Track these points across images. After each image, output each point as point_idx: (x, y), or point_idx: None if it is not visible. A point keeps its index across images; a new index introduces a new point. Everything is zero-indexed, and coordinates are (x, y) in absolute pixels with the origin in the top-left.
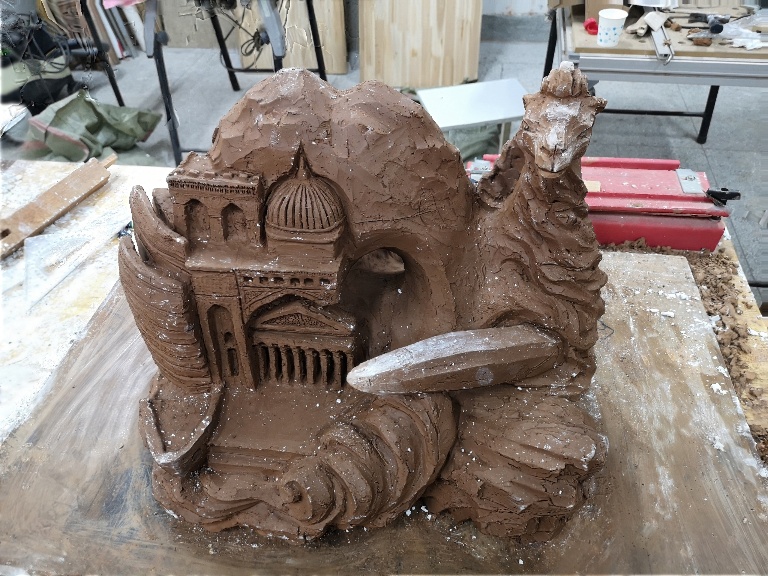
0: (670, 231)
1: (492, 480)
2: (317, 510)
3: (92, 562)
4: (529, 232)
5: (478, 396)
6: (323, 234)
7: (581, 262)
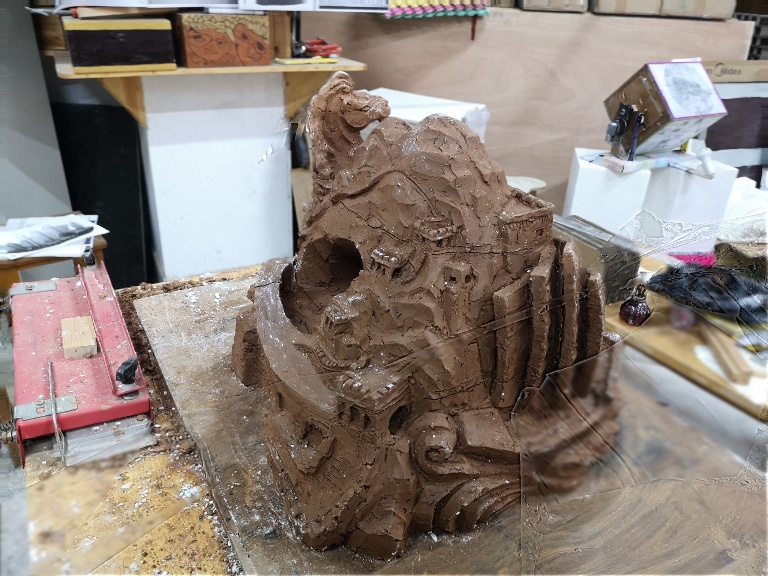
0: None
1: None
2: None
3: None
4: None
5: None
6: None
7: None
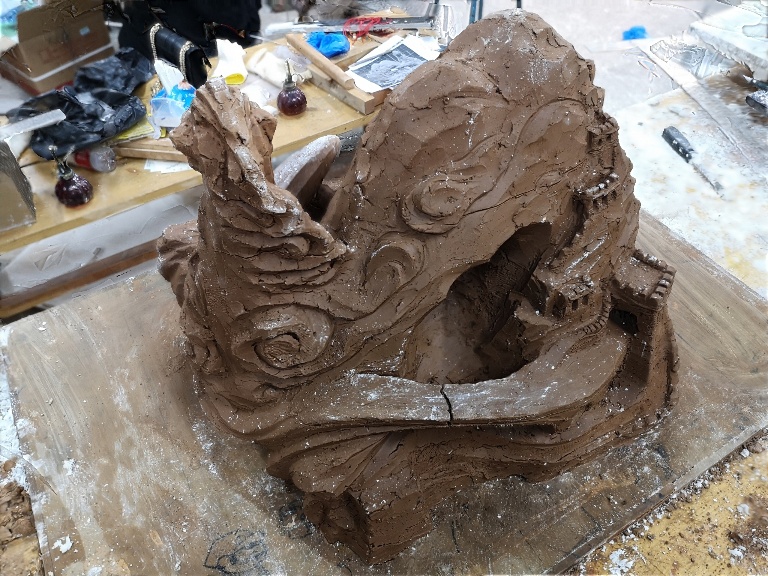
0: None
1: None
2: None
3: None
4: None
5: None
6: None
7: None
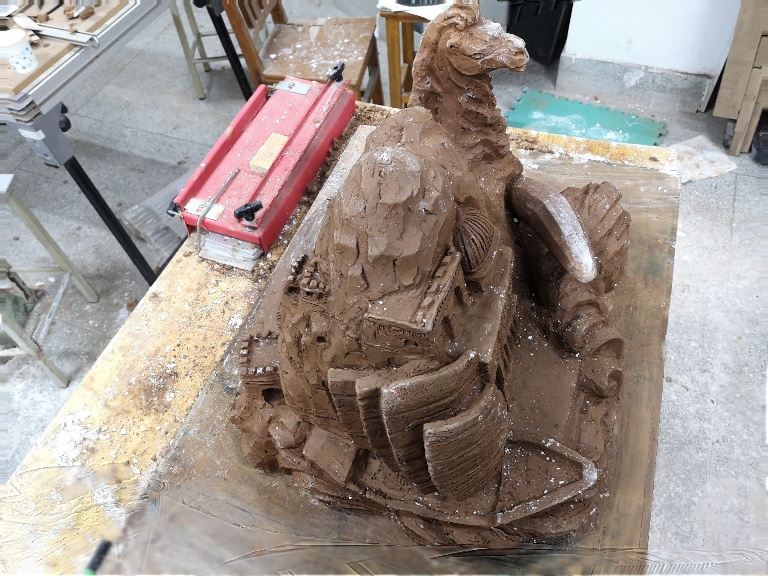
0: (340, 119)
1: (616, 250)
2: None
3: None
4: (482, 131)
5: None
6: None
7: None
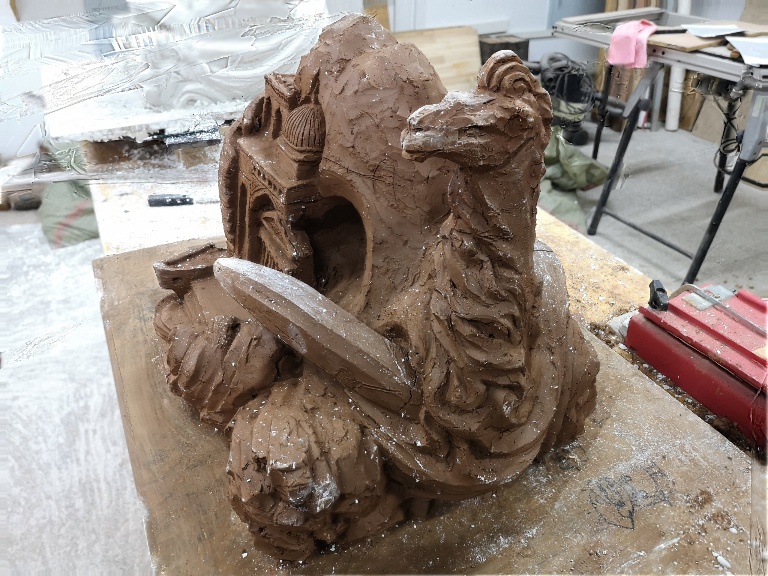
0: None
1: (236, 428)
2: (171, 359)
3: (120, 315)
4: None
5: (317, 376)
6: (296, 152)
7: (459, 306)
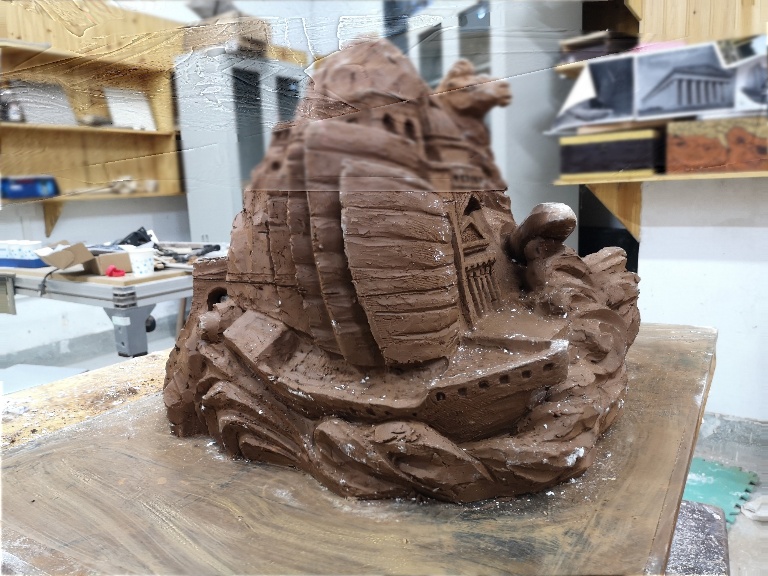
0: None
1: (619, 282)
2: None
3: (617, 569)
4: None
5: None
6: None
7: None
